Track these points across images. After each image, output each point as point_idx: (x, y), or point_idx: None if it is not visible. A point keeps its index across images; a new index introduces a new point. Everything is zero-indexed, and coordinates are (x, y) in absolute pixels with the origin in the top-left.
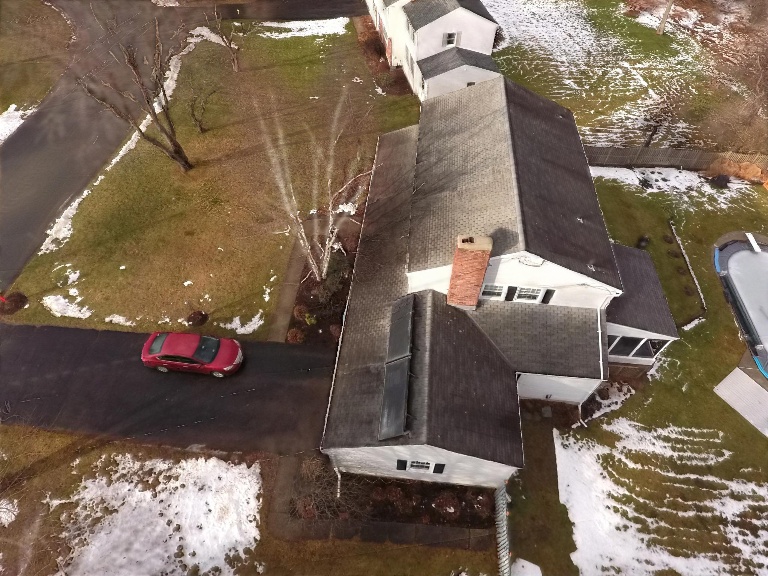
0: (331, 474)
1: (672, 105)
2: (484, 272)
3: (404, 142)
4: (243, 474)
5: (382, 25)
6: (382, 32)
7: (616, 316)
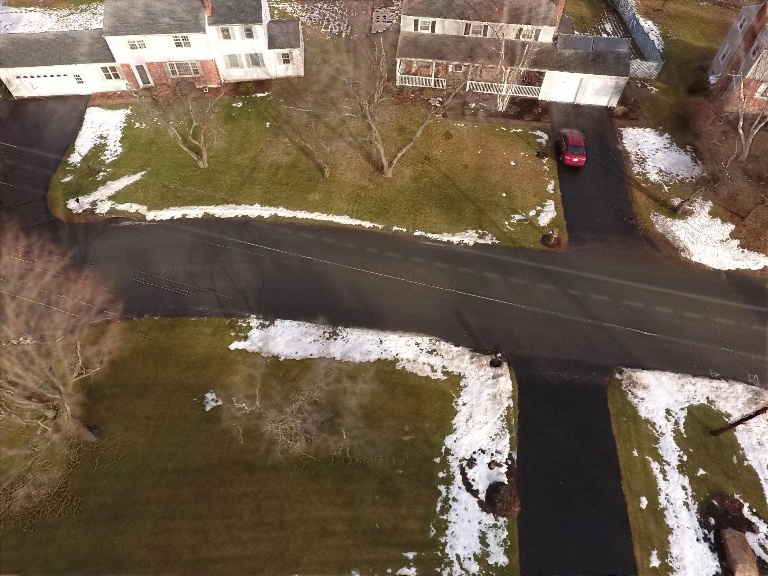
0: None
1: (295, 3)
2: None
3: (416, 42)
4: (626, 132)
5: (166, 69)
6: (168, 76)
7: None
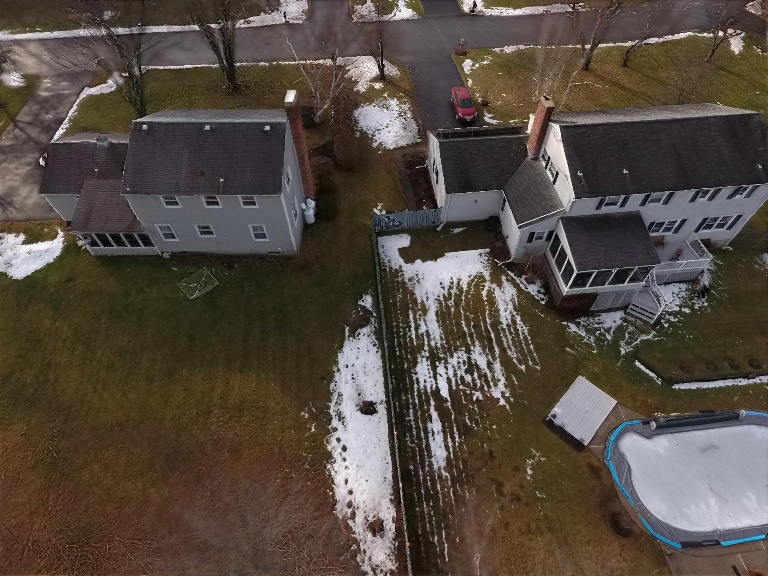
0: (425, 163)
1: None
2: (541, 126)
3: None
4: (415, 137)
5: None
6: None
7: (570, 226)
